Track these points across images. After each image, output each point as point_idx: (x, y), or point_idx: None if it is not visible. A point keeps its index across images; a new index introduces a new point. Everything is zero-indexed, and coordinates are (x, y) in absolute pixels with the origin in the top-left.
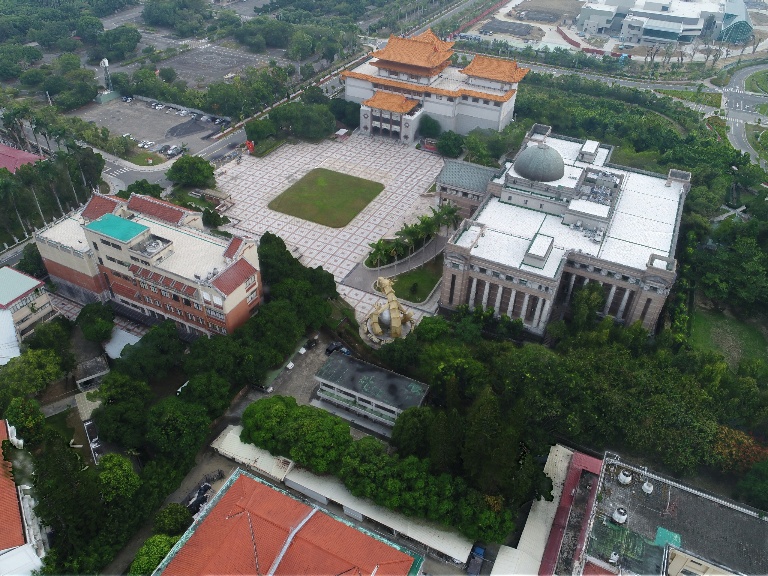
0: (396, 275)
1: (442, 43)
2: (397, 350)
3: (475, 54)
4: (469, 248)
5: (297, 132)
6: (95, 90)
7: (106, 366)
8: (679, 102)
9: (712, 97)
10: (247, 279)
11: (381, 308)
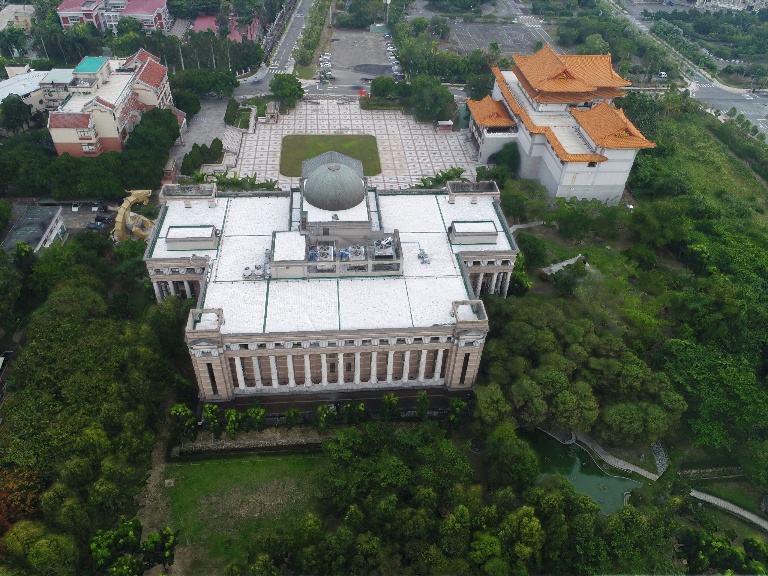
0: None
1: (612, 77)
2: (76, 234)
3: None
4: None
5: (410, 104)
6: (370, 20)
7: None
8: None
9: None
10: (81, 130)
11: None
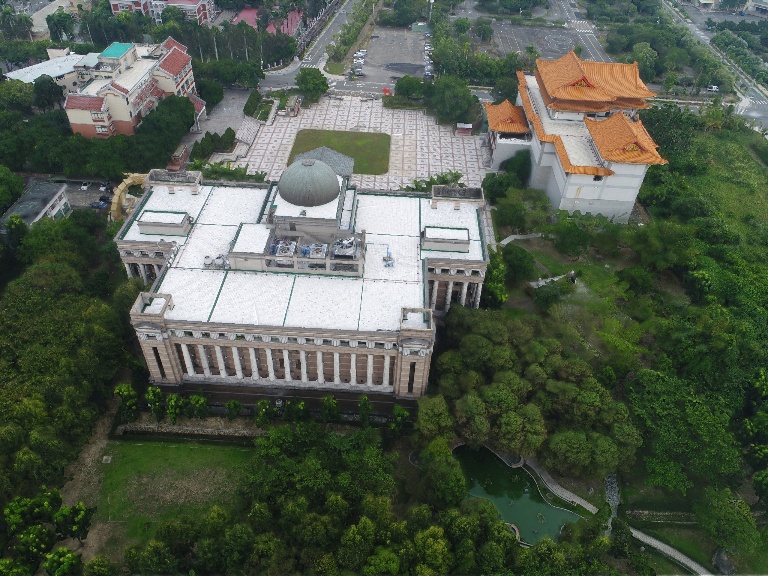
0: None
1: (636, 87)
2: None
3: None
4: (144, 180)
5: None
6: (413, 18)
7: None
8: None
9: None
10: (95, 112)
11: None
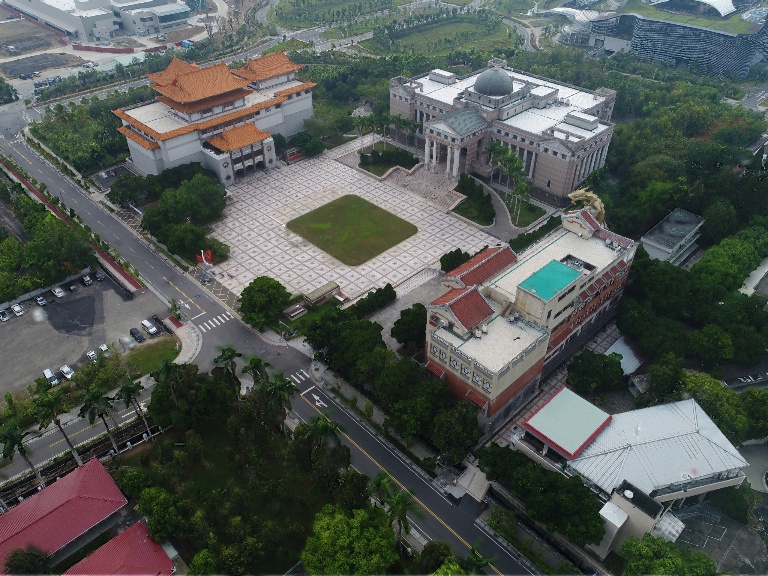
0: (510, 213)
1: None
2: (637, 214)
3: (79, 94)
4: (585, 137)
5: (206, 217)
6: None
7: (647, 374)
8: (306, 50)
9: (296, 42)
10: None
11: (598, 207)
